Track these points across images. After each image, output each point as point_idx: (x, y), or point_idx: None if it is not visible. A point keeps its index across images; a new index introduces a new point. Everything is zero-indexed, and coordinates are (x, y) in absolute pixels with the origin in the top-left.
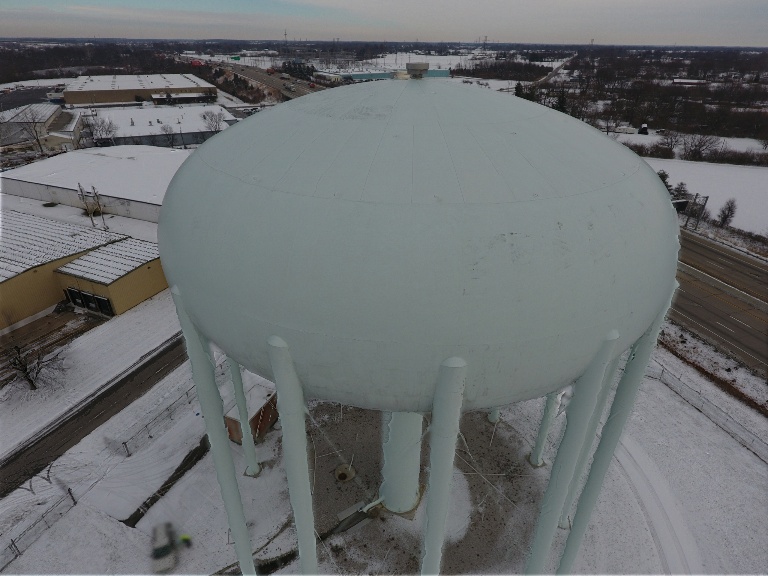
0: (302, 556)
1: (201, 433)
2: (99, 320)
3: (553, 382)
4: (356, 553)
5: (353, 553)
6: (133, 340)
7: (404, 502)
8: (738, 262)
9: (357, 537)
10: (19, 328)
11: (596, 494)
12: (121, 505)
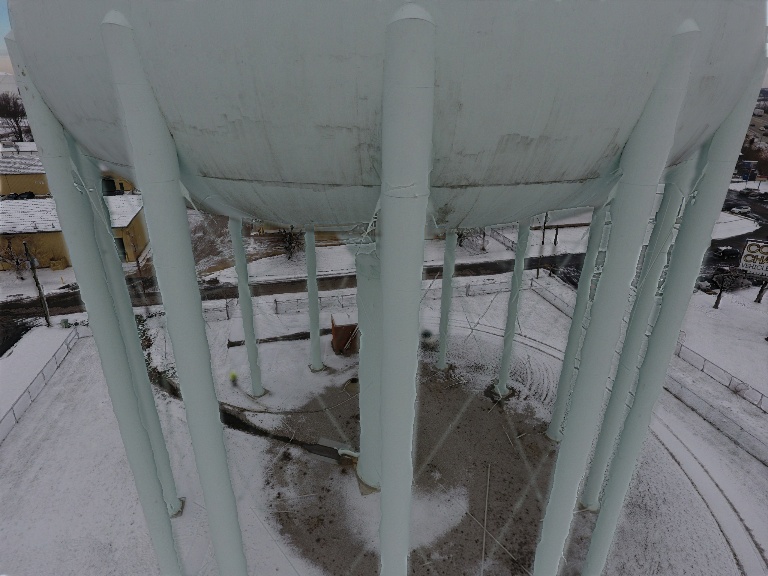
0: None
1: (323, 326)
2: (367, 243)
3: (95, 111)
4: (293, 471)
5: (291, 469)
6: None
7: (368, 470)
8: None
9: (310, 463)
10: (327, 231)
11: (383, 539)
12: (239, 333)
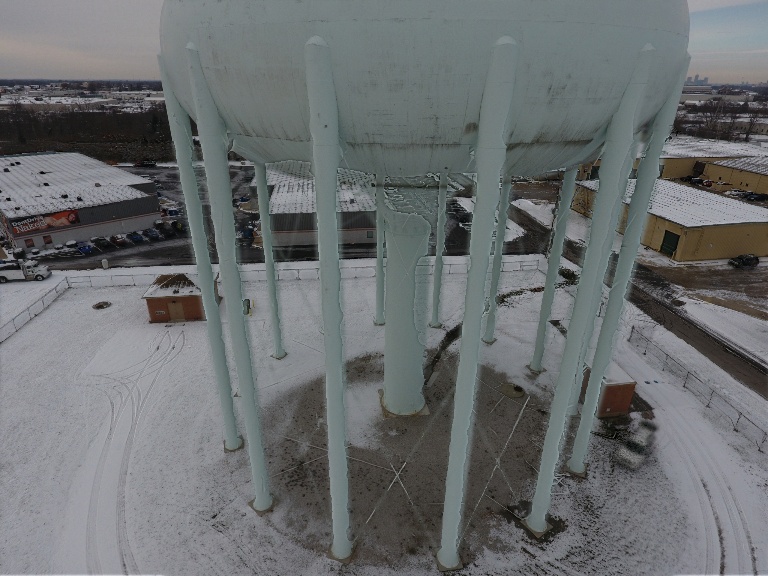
0: None
1: None
2: None
3: None
4: None
5: None
6: None
7: None
8: None
9: None
10: None
11: None
12: None
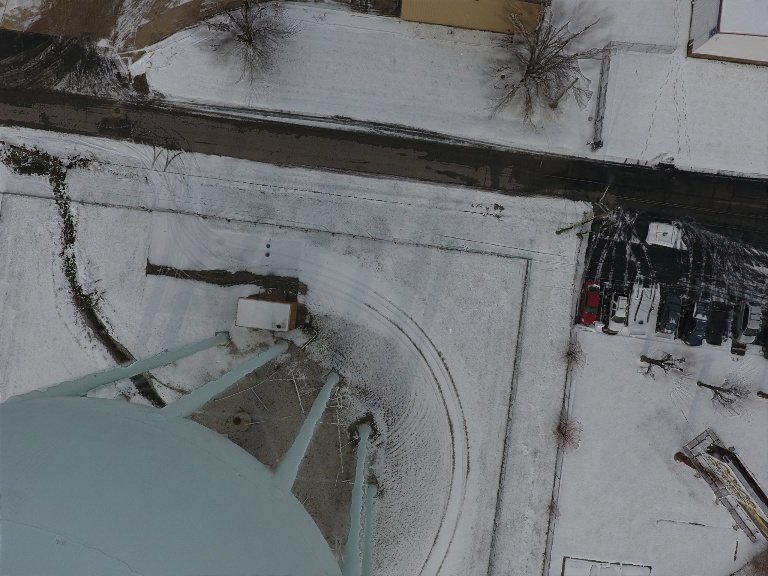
0: None
1: (246, 266)
2: None
3: None
4: None
5: None
6: (361, 81)
7: None
8: None
9: None
10: None
11: None
12: (159, 250)
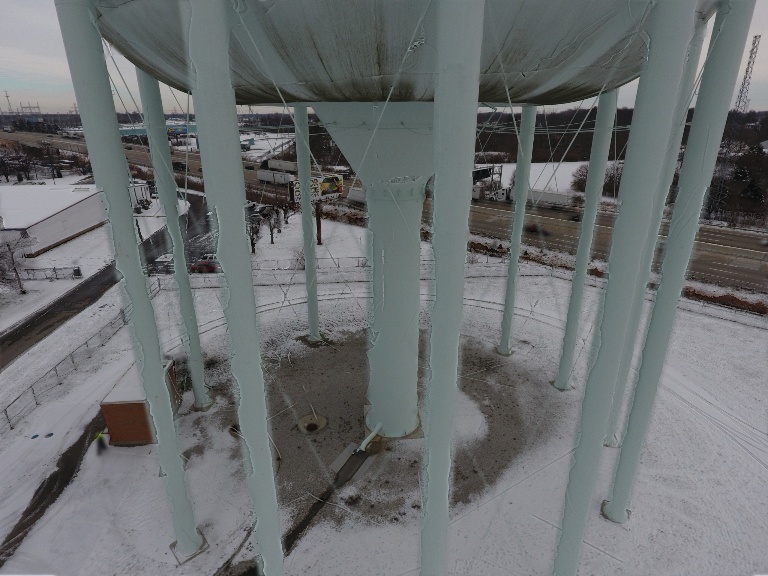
0: (449, 354)
1: (53, 454)
2: None
3: None
4: (381, 493)
5: (377, 495)
6: None
7: (408, 419)
8: (542, 207)
9: (371, 478)
10: None
11: None
12: None
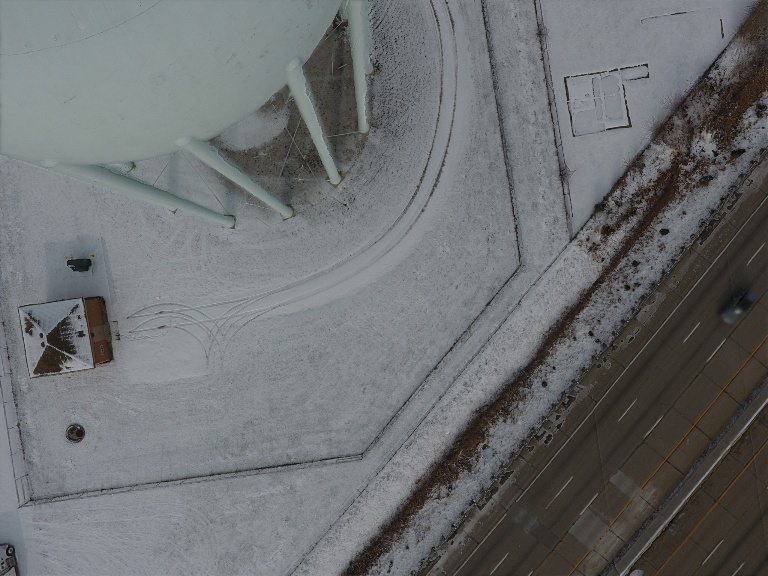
0: None
1: None
2: None
3: None
4: None
5: None
6: None
7: None
8: None
9: None
10: None
11: None
12: None
